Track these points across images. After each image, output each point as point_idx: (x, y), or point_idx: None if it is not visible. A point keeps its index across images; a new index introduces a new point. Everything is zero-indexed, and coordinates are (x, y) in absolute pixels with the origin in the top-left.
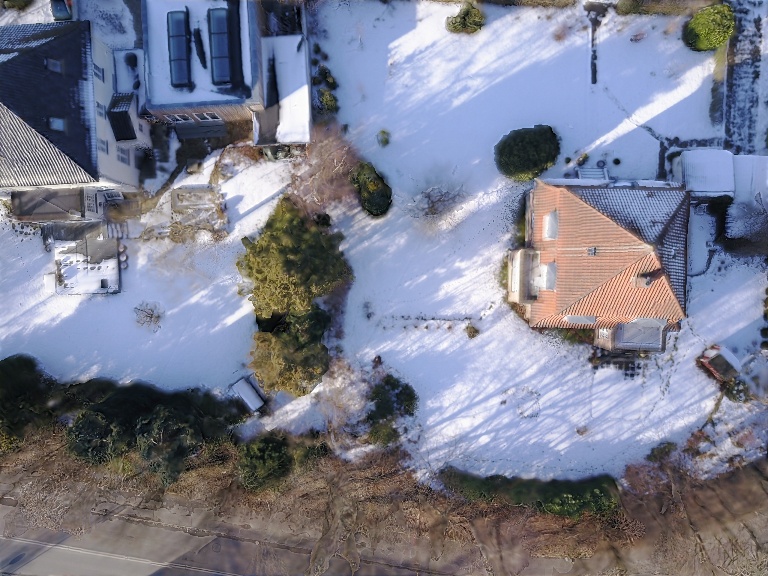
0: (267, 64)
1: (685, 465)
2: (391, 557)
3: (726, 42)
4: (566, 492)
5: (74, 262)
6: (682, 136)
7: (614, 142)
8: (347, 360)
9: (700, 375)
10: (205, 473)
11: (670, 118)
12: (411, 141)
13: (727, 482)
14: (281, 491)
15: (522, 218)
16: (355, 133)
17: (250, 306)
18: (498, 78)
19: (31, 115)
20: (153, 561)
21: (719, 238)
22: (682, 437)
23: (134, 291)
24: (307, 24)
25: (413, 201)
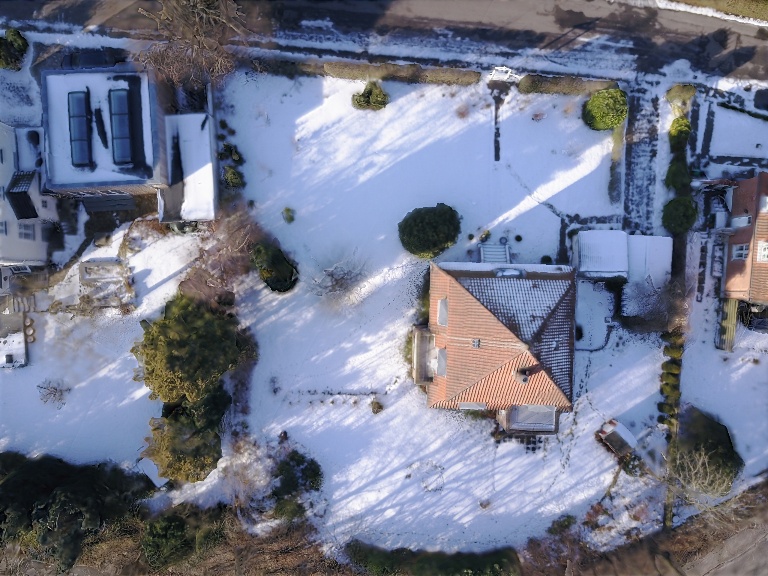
0: (171, 142)
1: (585, 537)
2: None
3: (622, 124)
4: (467, 567)
5: None
6: (582, 213)
7: (516, 219)
8: (253, 435)
9: (599, 448)
10: (115, 546)
11: (571, 195)
12: (318, 216)
13: (625, 554)
14: (191, 563)
15: (427, 293)
16: (263, 208)
17: None
18: (403, 155)
19: None
20: None
21: (616, 315)
22: (582, 509)
23: (41, 365)
24: (214, 100)
25: (319, 277)
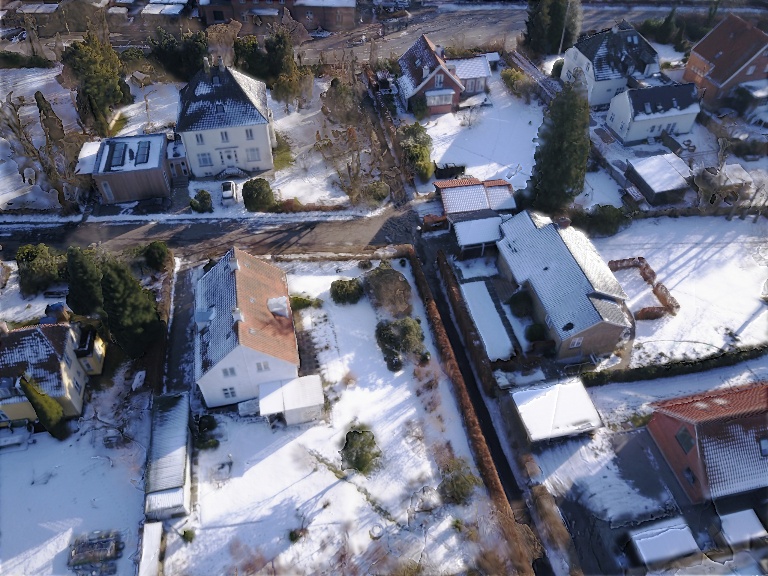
0: None
1: None
2: None
3: None
4: None
5: None
6: None
7: None
8: None
9: None
10: None
11: None
12: None
13: None
14: None
15: None
16: None
17: None
18: None
19: None
20: None
21: None
22: None
23: None
24: None
25: None
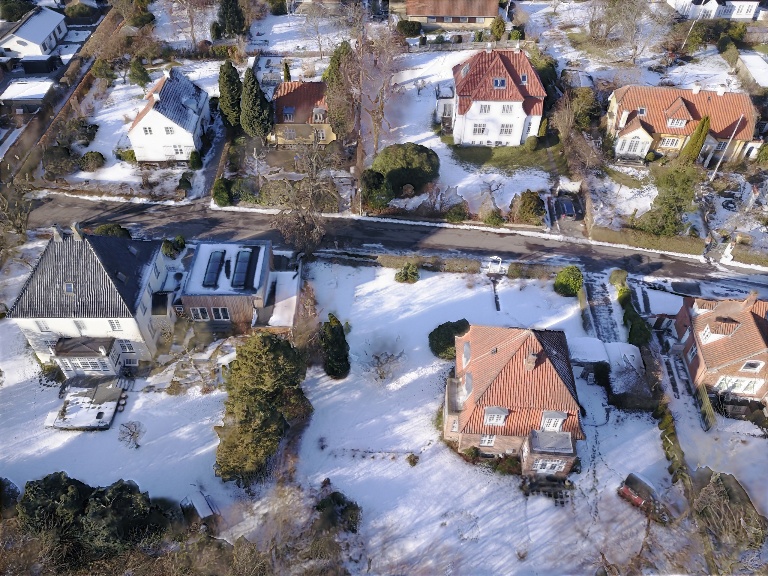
0: (271, 284)
1: None
2: None
3: (582, 288)
4: None
5: (80, 403)
6: None
7: None
8: (299, 480)
9: (624, 503)
10: None
11: (556, 330)
12: (368, 336)
13: None
14: None
15: None
16: None
17: None
18: (431, 305)
19: (109, 265)
20: None
21: (609, 395)
22: (623, 562)
23: None
24: None
25: None
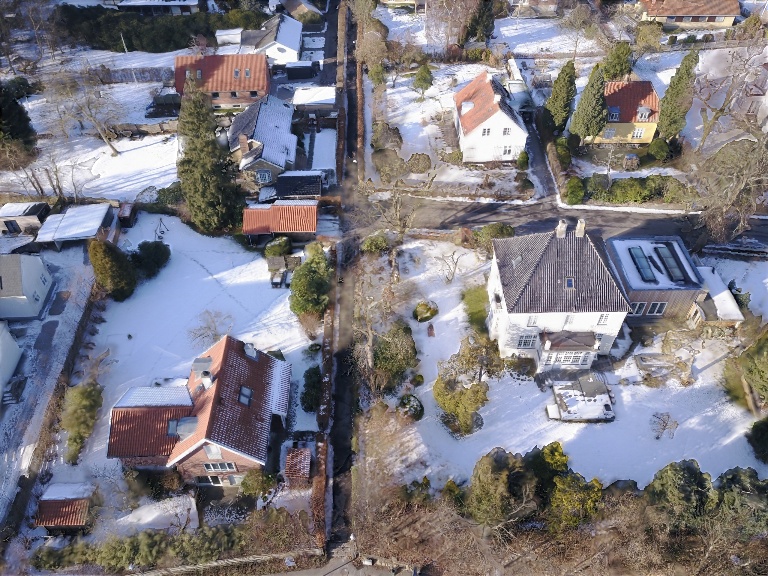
0: None
1: None
2: None
3: None
4: None
5: (572, 396)
6: None
7: None
8: None
9: None
10: None
11: None
12: None
13: None
14: None
15: None
16: None
17: (737, 431)
18: None
19: None
20: None
21: None
22: None
23: (626, 420)
24: None
25: None
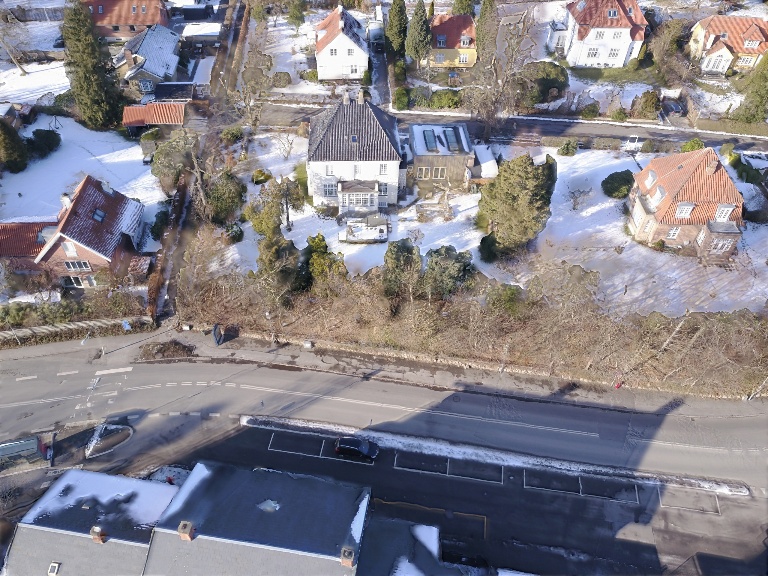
0: None
1: None
2: (602, 402)
3: None
4: None
5: (359, 226)
6: None
7: None
8: (544, 262)
9: None
10: (448, 337)
11: None
12: None
13: None
14: (508, 347)
15: (628, 211)
16: None
17: (473, 245)
18: (592, 169)
19: (381, 123)
20: (405, 407)
21: (745, 213)
22: None
23: None
24: None
25: None
